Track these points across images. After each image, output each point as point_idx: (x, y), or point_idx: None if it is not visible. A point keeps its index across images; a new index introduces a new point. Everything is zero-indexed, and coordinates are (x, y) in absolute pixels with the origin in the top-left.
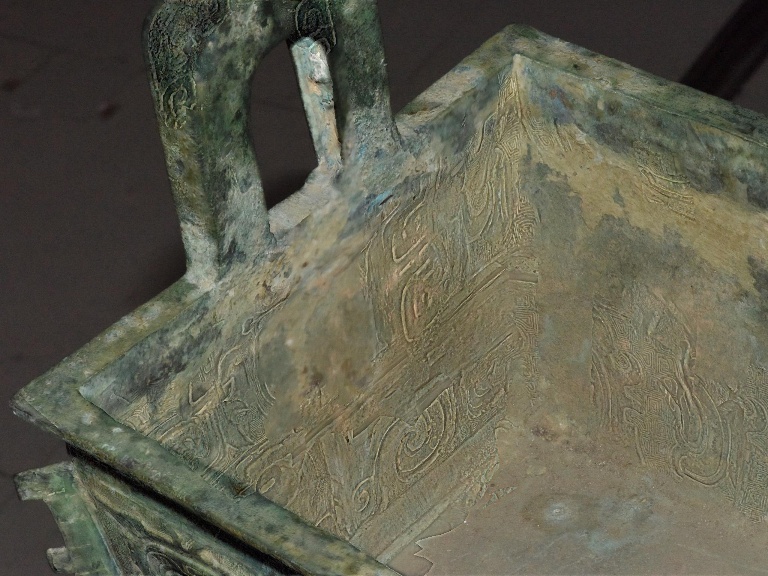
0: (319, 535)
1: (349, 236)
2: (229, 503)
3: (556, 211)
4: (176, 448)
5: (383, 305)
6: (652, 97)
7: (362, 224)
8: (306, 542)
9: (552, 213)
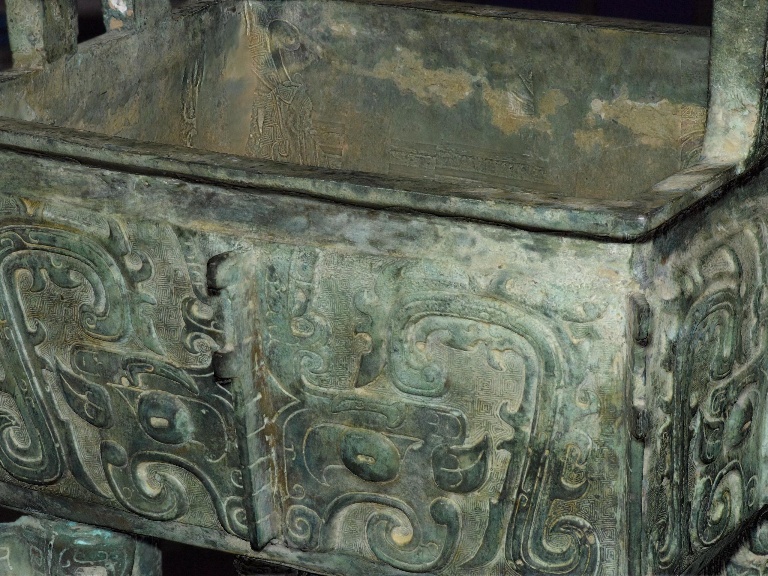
0: (621, 26)
1: (739, 188)
2: (698, 29)
3: None
4: None
5: None
6: (464, 187)
7: (731, 190)
8: (628, 23)
9: None
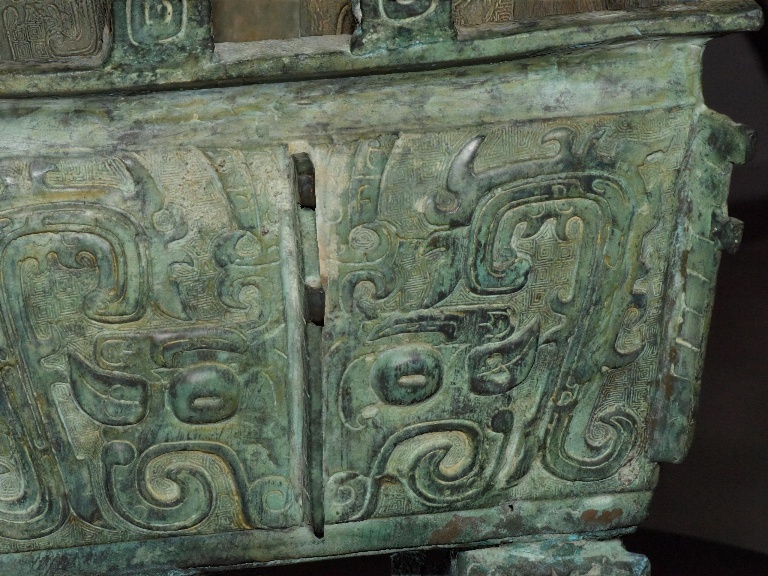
0: None
1: None
2: None
3: (521, 2)
4: (39, 7)
5: (314, 7)
6: None
7: None
8: None
9: (519, 4)
